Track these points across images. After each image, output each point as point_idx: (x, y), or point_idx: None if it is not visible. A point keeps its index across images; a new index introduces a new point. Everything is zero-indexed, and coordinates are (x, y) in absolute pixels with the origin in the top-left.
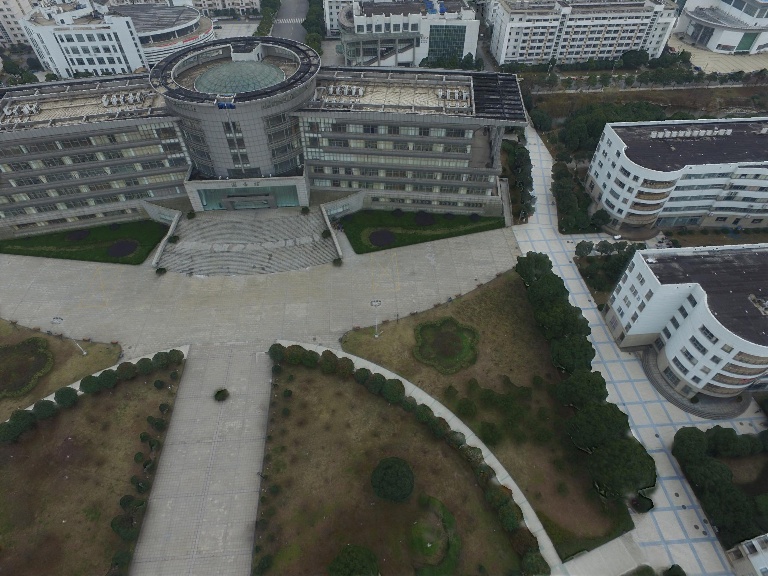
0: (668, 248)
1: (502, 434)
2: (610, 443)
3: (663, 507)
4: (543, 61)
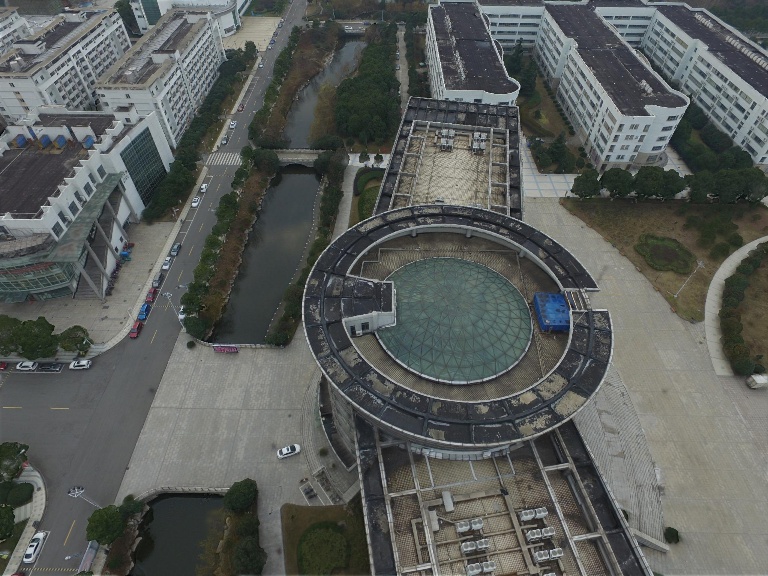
0: None
1: None
2: (751, 178)
3: None
4: None
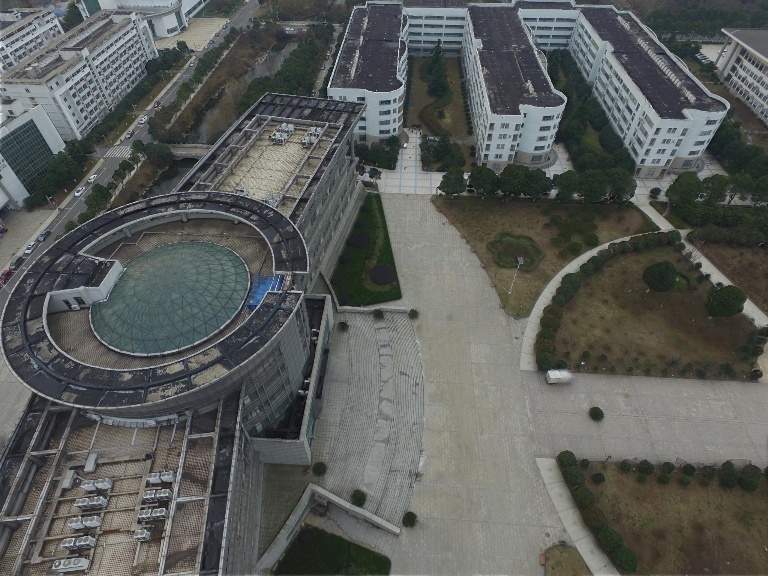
0: (488, 105)
1: (594, 234)
2: (614, 178)
3: None
4: (101, 113)
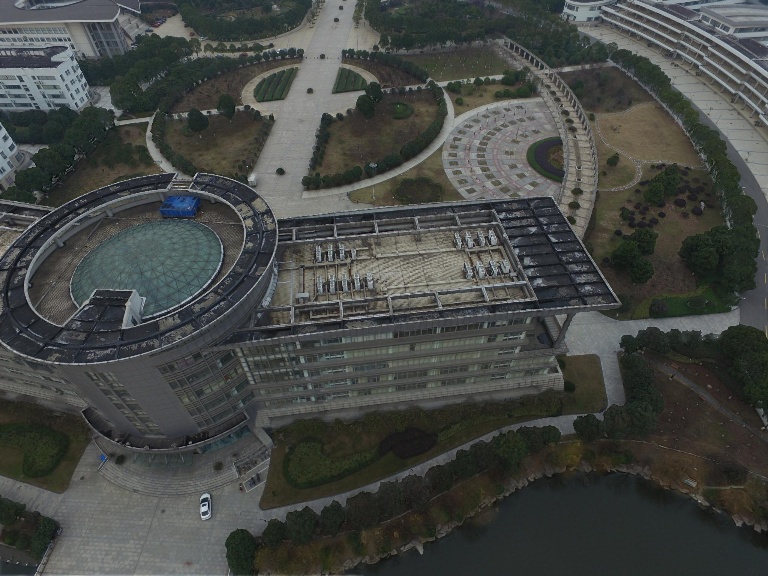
0: None
1: None
2: None
3: None
4: None
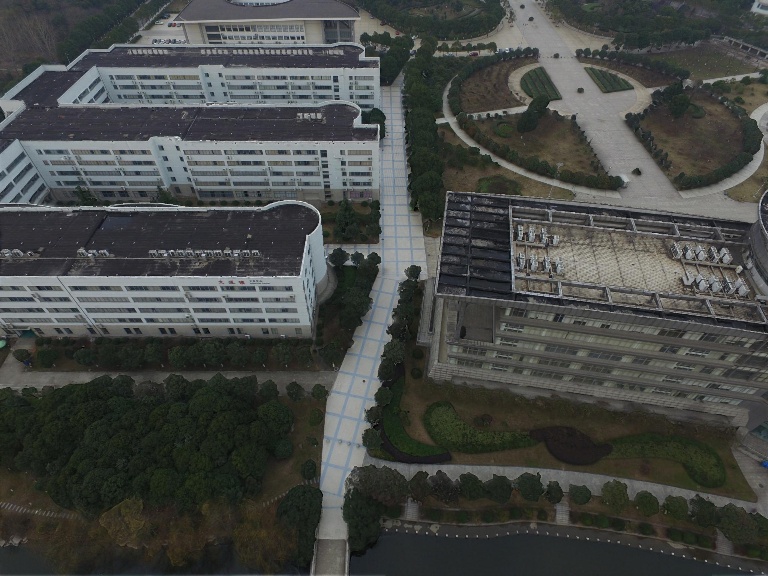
0: (355, 142)
1: None
2: None
3: (397, 133)
4: None
